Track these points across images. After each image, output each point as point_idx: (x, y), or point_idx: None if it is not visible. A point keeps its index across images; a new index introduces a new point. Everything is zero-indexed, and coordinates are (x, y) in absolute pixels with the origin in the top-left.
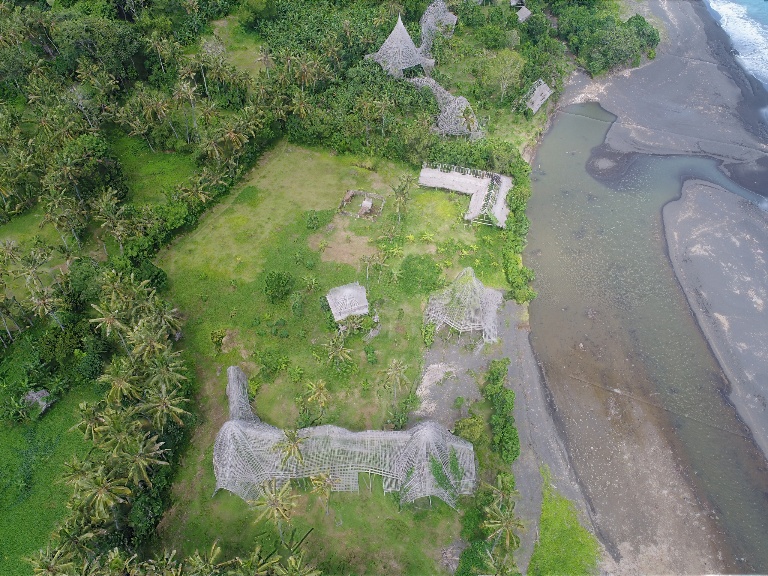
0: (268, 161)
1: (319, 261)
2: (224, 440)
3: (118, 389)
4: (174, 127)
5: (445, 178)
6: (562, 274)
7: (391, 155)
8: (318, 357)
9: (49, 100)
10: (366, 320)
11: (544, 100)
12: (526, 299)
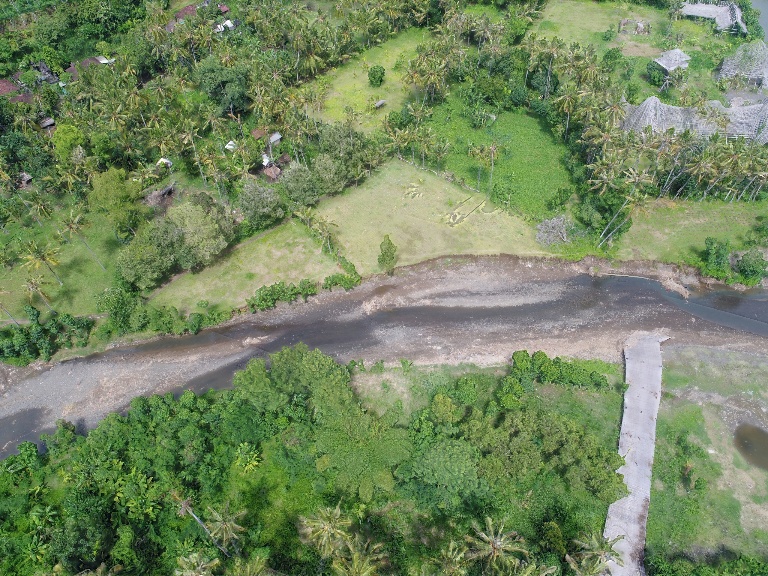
0: (549, 7)
1: (623, 55)
2: (645, 110)
3: (592, 71)
4: None
5: (693, 8)
6: None
7: (641, 0)
8: (656, 95)
9: None
10: None
11: None
12: None
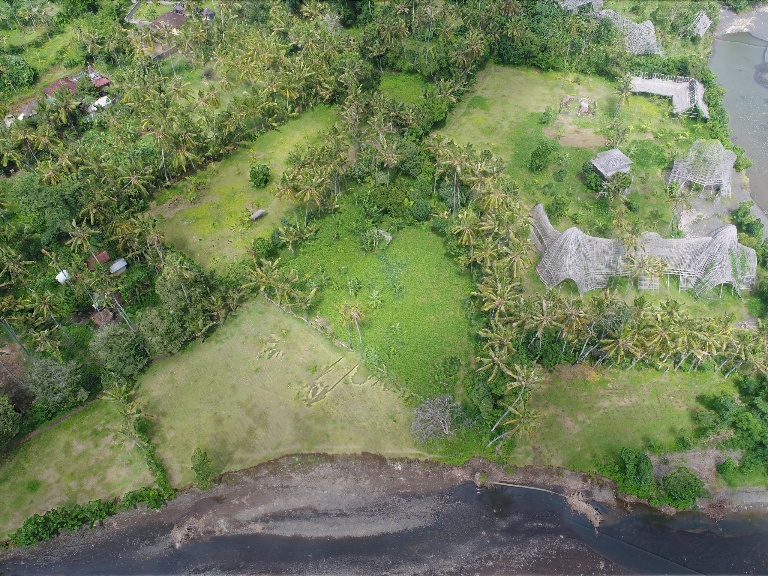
0: (483, 78)
1: (559, 145)
2: (565, 243)
3: (496, 199)
4: (402, 51)
5: (647, 84)
6: (762, 154)
7: (590, 70)
8: (591, 206)
9: (292, 31)
10: (628, 177)
11: (707, 28)
12: (746, 166)
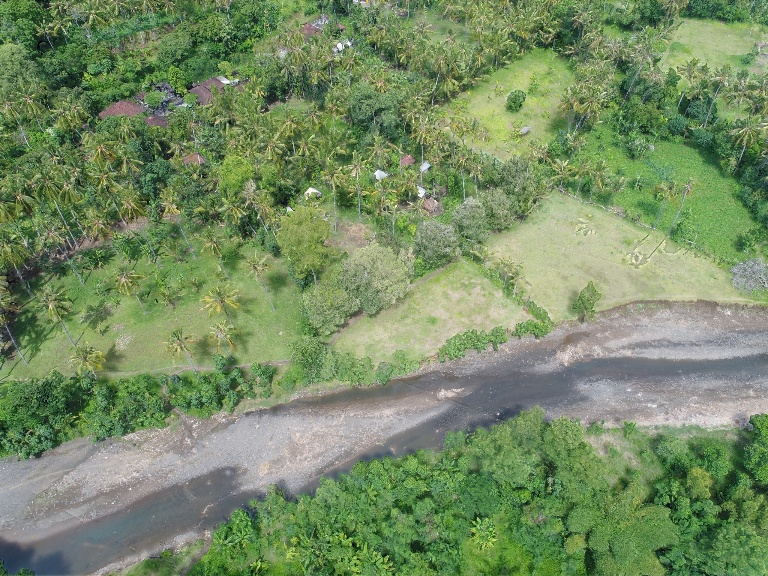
0: None
1: None
2: None
3: None
4: None
5: None
6: None
7: None
8: None
9: None
10: None
11: None
12: None
